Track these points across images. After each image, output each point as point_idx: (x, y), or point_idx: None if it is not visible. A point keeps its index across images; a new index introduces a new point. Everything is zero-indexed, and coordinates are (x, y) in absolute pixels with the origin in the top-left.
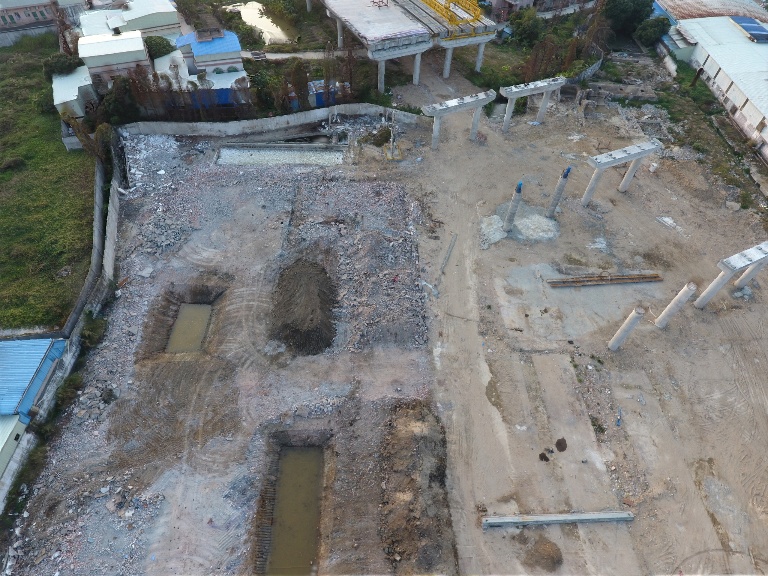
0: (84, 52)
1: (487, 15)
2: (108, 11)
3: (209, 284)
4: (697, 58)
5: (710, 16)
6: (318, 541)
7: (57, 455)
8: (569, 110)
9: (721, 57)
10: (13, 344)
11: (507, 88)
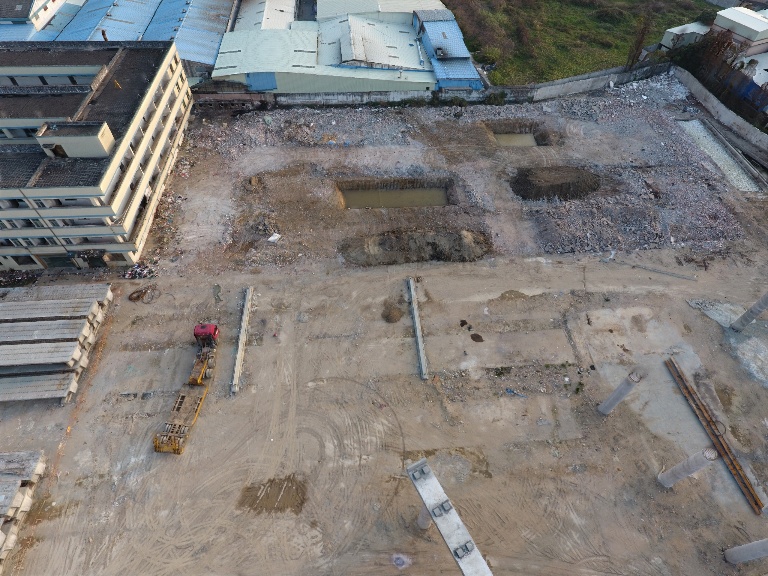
0: (724, 12)
1: None
2: None
3: (551, 137)
4: None
5: None
6: None
7: (424, 108)
8: None
9: None
10: (473, 68)
11: None
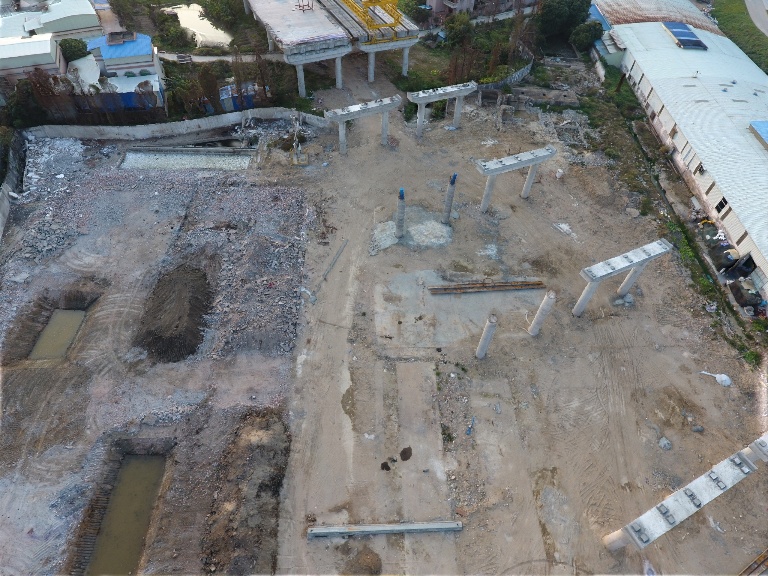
0: None
1: (424, 19)
2: (28, 13)
3: (84, 290)
4: (626, 63)
5: (644, 21)
6: (141, 551)
7: None
8: (489, 115)
9: (645, 63)
10: None
11: (414, 93)
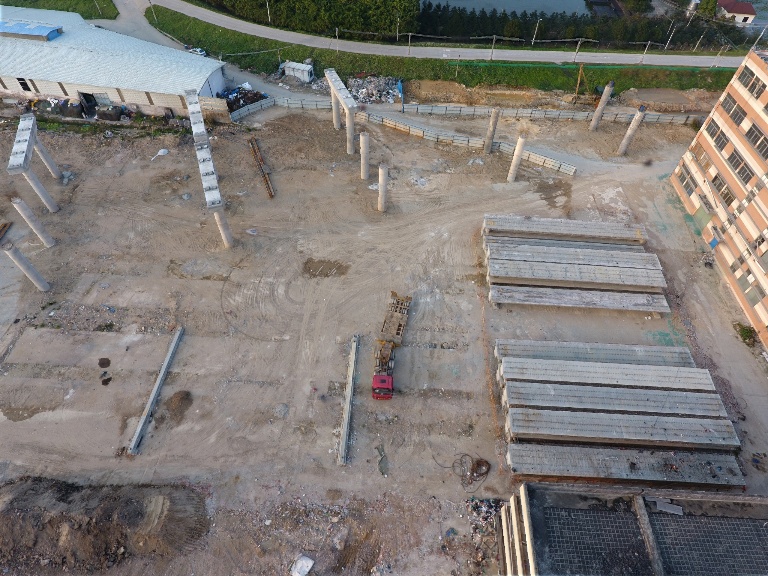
0: None
1: None
2: None
3: None
4: None
5: None
6: None
7: None
8: None
9: None
10: None
11: None
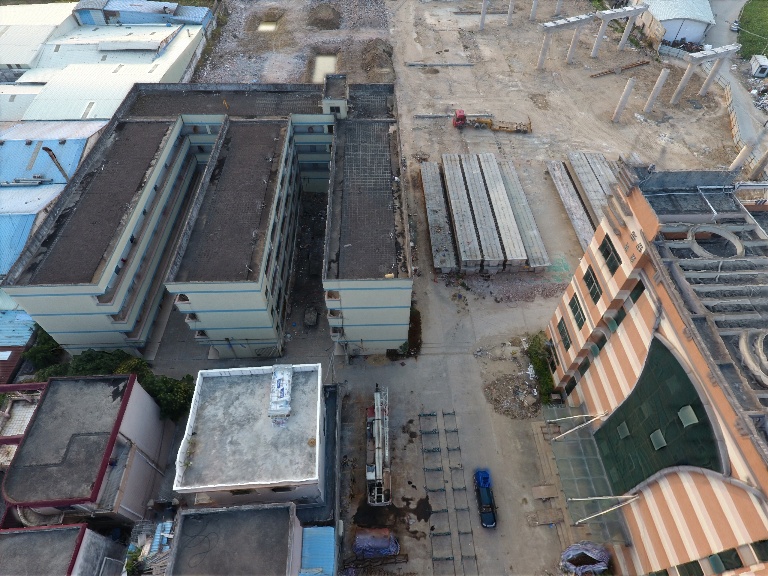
0: None
1: None
2: None
3: (275, 12)
4: None
5: None
6: None
7: None
8: None
9: None
10: (193, 7)
11: None
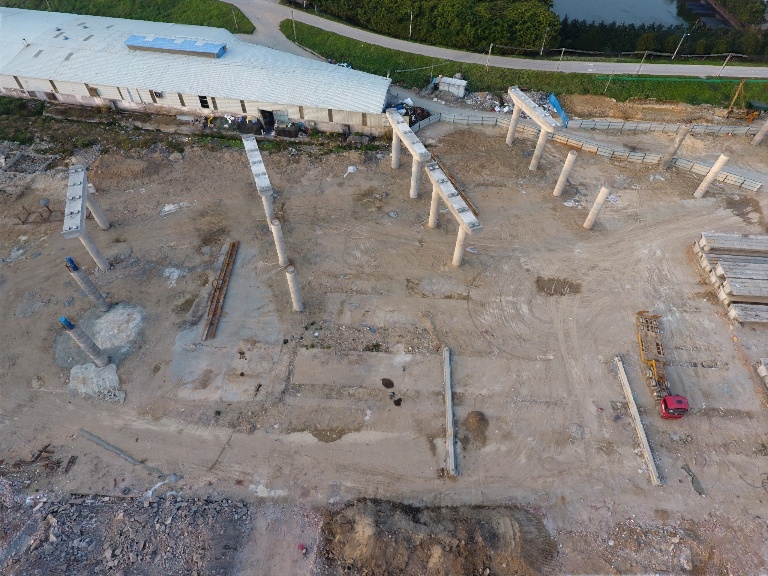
0: None
1: None
2: None
3: None
4: None
5: None
6: None
7: None
8: None
9: None
10: None
11: None
